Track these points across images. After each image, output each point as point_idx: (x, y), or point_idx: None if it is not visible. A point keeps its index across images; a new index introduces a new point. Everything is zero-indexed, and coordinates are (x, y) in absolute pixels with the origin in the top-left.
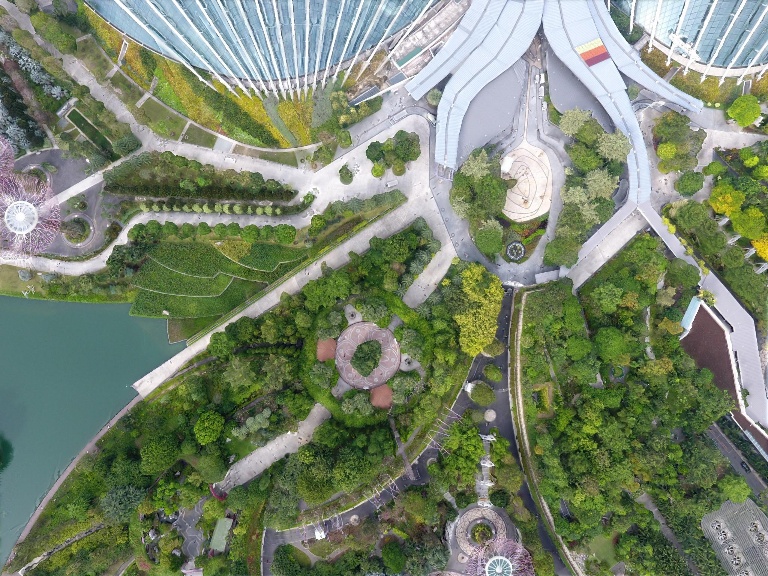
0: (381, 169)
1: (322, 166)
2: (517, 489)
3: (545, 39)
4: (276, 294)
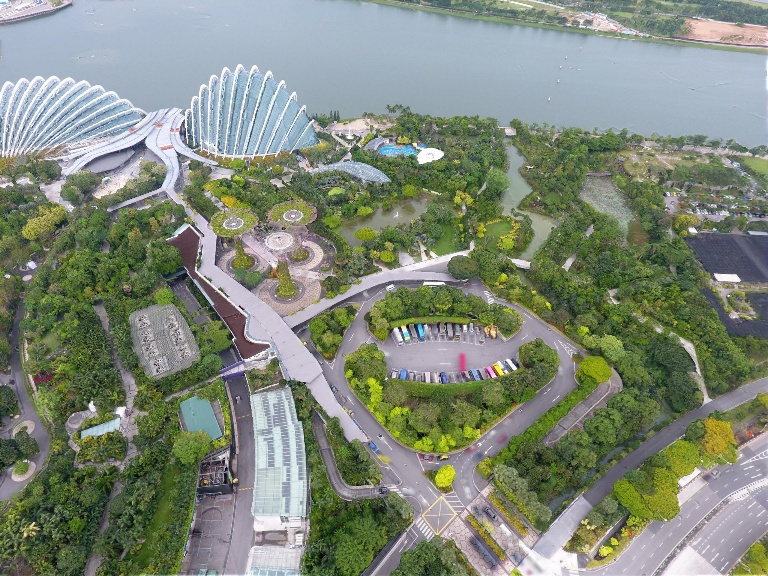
0: None
1: (8, 182)
2: (3, 292)
3: (145, 144)
4: None
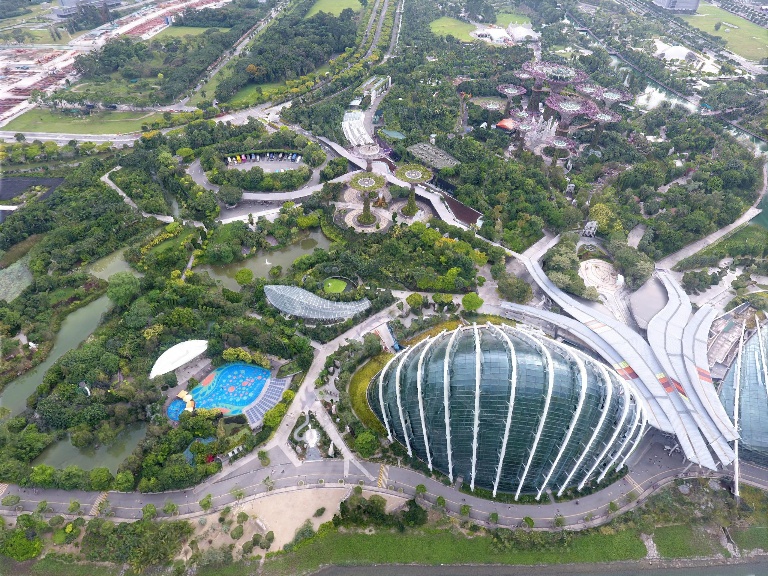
0: (703, 270)
1: None
2: None
3: None
4: (716, 237)
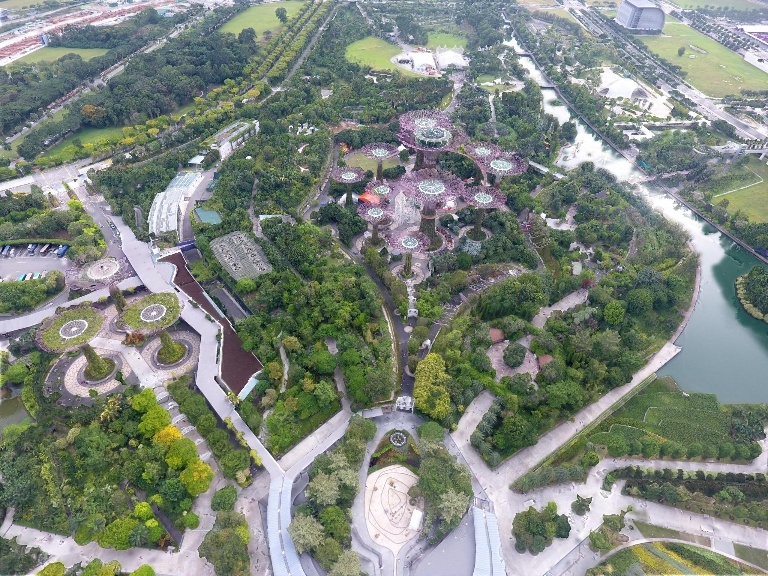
0: None
1: None
2: None
3: None
4: (601, 408)
